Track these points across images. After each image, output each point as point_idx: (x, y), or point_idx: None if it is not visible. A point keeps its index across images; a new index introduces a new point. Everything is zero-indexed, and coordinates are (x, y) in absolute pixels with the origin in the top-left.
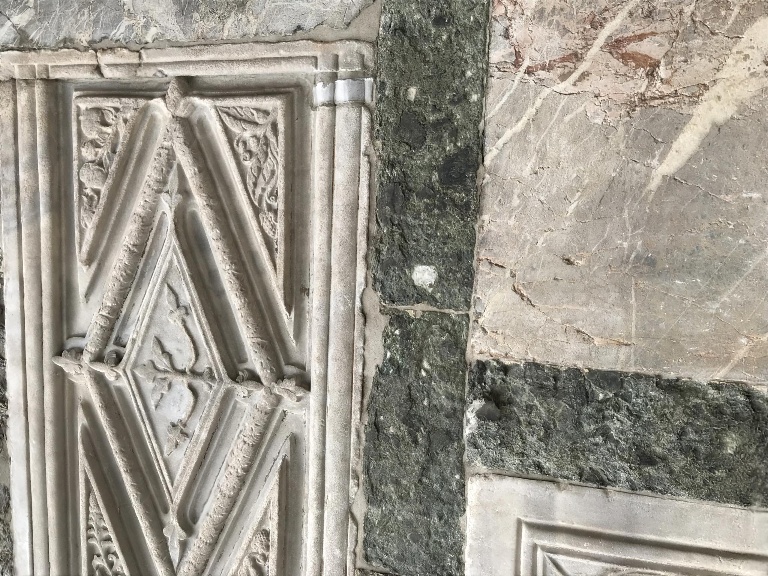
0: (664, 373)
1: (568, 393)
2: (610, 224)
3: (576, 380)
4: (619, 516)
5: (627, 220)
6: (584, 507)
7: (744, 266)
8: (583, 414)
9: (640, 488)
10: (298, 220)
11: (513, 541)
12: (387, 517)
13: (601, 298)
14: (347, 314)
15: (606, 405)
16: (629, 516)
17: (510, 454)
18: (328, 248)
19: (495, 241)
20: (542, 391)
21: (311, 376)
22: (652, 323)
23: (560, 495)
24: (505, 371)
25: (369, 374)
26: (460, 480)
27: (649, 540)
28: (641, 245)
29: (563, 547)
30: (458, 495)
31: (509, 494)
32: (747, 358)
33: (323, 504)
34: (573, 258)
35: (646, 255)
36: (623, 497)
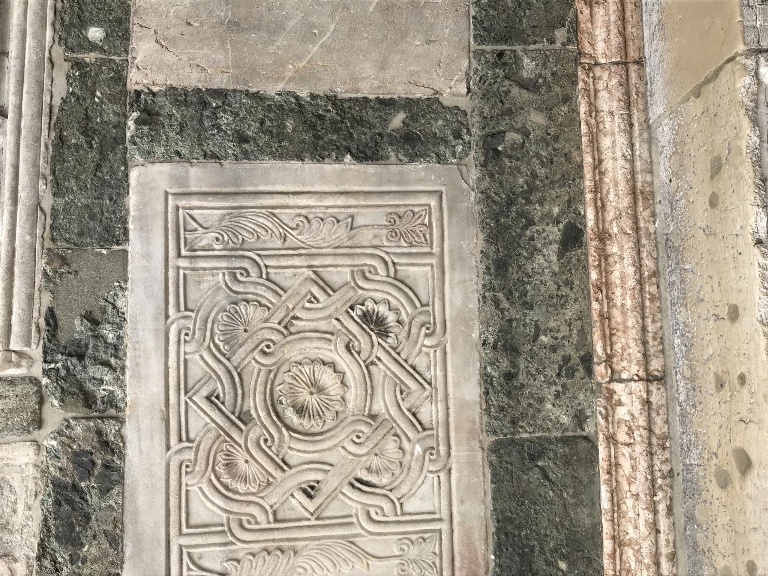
0: (250, 89)
1: (194, 103)
2: (213, 2)
3: (198, 95)
4: (229, 178)
5: (222, 0)
6: (208, 175)
7: (286, 26)
8: (204, 116)
9: (241, 159)
10: (1, 4)
11: (162, 206)
12: (69, 205)
13: (210, 45)
14: (39, 62)
15: (218, 111)
16: (235, 177)
17: (158, 147)
18: (24, 18)
19: (144, 12)
20: (177, 103)
21: (9, 110)
22: (240, 59)
23: (192, 170)
24: (153, 95)
25: (56, 104)
26: (124, 171)
27: (248, 192)
28: (231, 14)
29: (196, 205)
30: (123, 182)
31: (158, 174)
32: (293, 77)
33: (16, 203)
34: (192, 22)
35: (234, 20)
36: (231, 166)
